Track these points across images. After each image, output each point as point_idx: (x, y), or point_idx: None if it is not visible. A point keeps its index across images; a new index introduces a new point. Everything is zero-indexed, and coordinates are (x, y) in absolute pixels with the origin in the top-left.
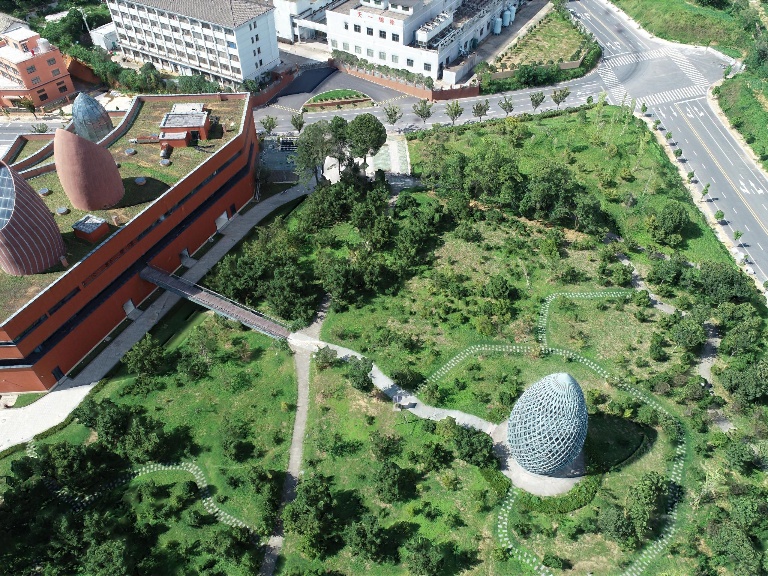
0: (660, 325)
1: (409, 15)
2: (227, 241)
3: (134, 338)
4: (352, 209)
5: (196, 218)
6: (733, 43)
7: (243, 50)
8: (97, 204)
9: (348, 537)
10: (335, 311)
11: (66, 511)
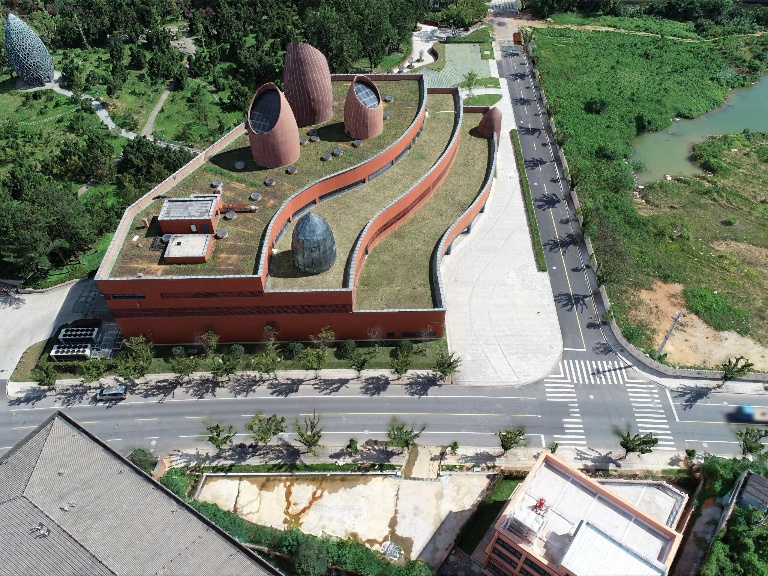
0: None
1: None
2: None
3: None
4: None
5: None
6: None
7: None
8: None
9: None
10: None
11: None
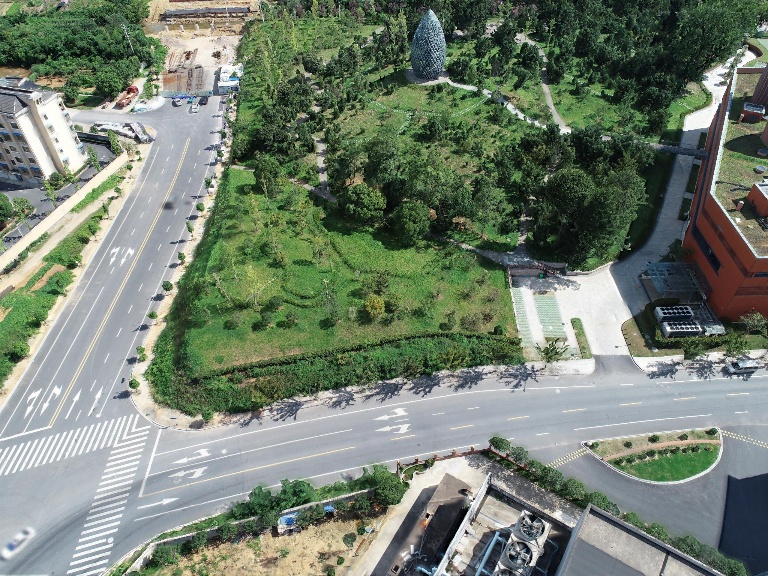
0: None
1: None
2: (671, 214)
3: None
4: None
5: None
6: None
7: None
8: None
9: None
10: None
11: None
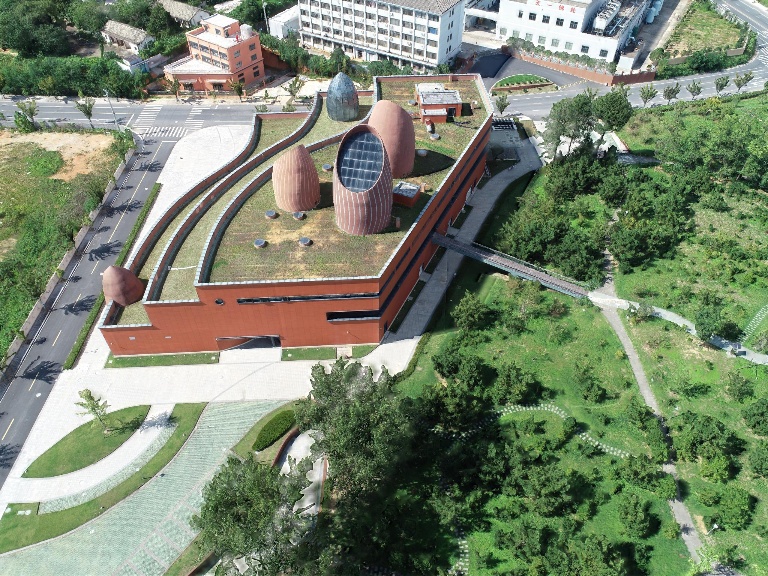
0: None
1: (587, 3)
2: (478, 212)
3: (434, 298)
4: (595, 182)
5: (461, 189)
6: None
7: (442, 36)
8: (399, 173)
9: (759, 460)
10: (623, 272)
11: (449, 446)
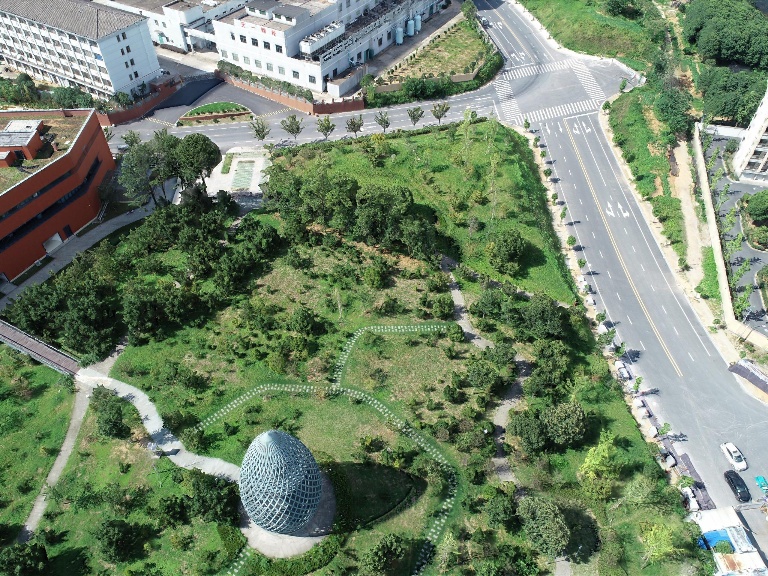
0: (469, 363)
1: (293, 26)
2: (55, 265)
3: None
4: None
5: (13, 242)
6: (640, 55)
7: (111, 62)
8: None
9: None
10: (133, 345)
11: None
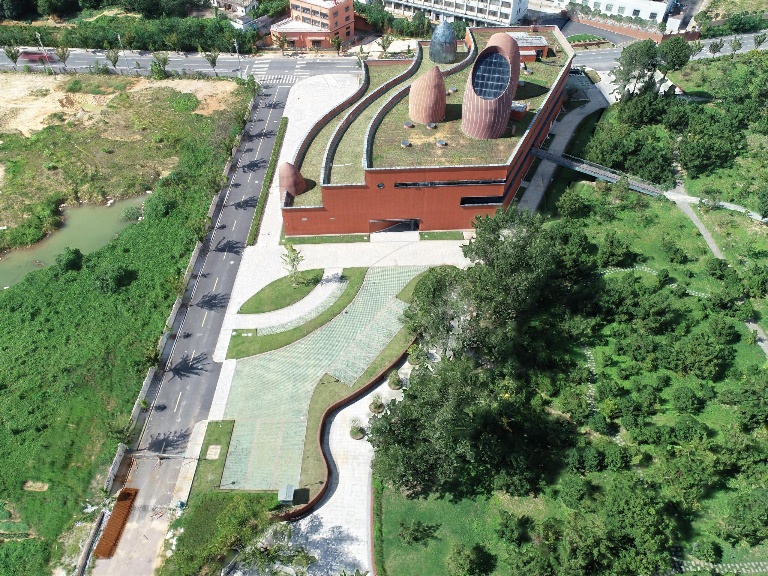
0: None
1: None
2: (560, 139)
3: (535, 198)
4: (659, 114)
5: (549, 116)
6: None
7: None
8: None
9: None
10: (691, 178)
11: None
